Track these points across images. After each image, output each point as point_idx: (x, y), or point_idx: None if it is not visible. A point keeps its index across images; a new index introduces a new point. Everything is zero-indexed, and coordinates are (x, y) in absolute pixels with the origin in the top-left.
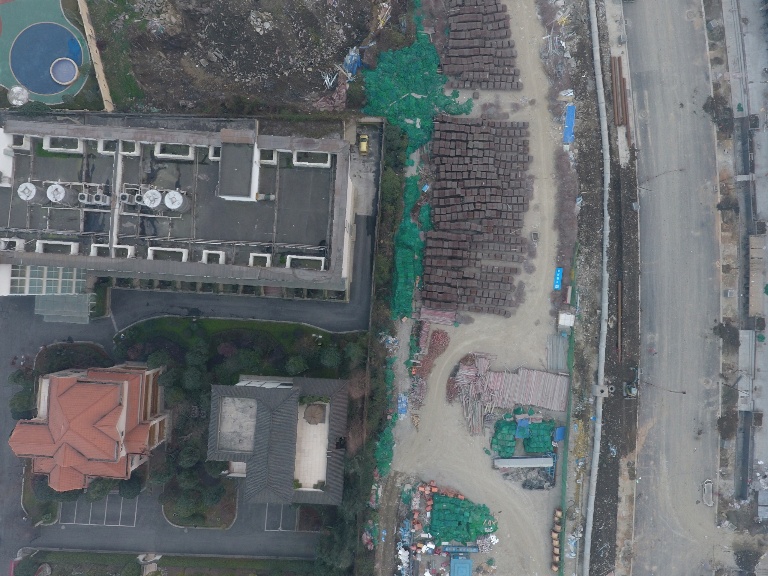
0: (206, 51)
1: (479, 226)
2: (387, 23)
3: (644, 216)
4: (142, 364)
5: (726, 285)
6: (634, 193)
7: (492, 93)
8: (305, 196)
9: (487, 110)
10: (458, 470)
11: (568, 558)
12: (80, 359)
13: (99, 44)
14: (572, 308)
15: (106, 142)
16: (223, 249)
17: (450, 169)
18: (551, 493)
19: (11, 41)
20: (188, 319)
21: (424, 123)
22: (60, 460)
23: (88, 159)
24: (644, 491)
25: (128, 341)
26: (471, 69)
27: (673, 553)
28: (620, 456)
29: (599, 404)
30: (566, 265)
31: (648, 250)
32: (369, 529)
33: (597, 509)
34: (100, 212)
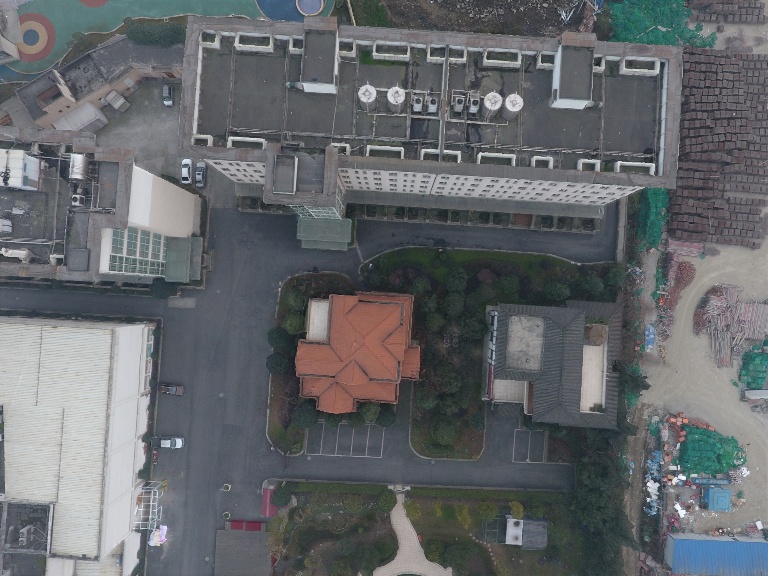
0: None
1: (729, 157)
2: None
3: None
4: None
5: None
6: None
7: (736, 27)
8: (629, 104)
9: (732, 43)
10: (706, 402)
11: None
12: (328, 289)
13: None
14: None
15: (432, 49)
16: None
17: (700, 100)
18: None
19: None
20: (434, 250)
21: None
22: (347, 378)
23: (412, 67)
24: None
25: (378, 270)
26: (720, 1)
27: None
28: None
29: None
30: None
31: None
32: None
33: None
34: (425, 119)
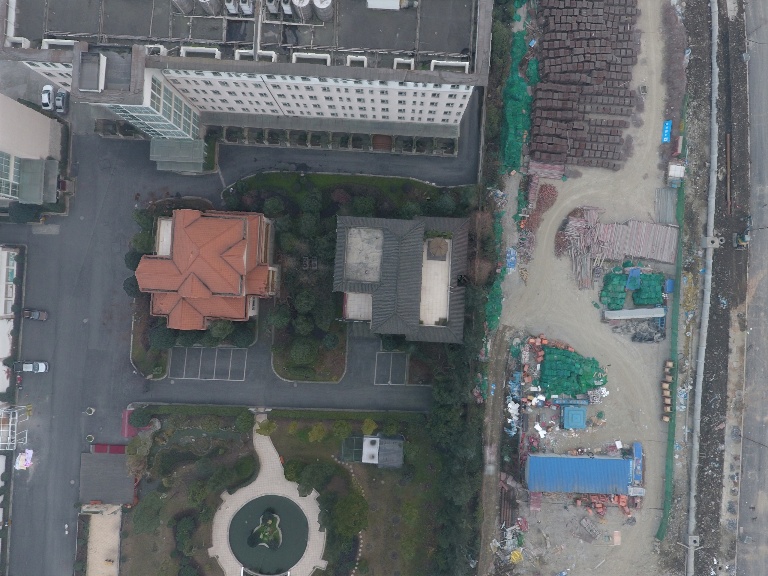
0: None
1: (589, 77)
2: None
3: (753, 68)
4: None
5: None
6: (743, 44)
7: None
8: (447, 4)
9: None
10: (567, 324)
11: (678, 411)
12: None
13: None
14: (681, 161)
15: None
16: None
17: (559, 21)
18: (660, 346)
19: None
20: (296, 174)
21: None
22: (187, 291)
23: None
24: (755, 342)
25: (238, 194)
26: None
27: None
28: (730, 307)
29: (709, 255)
30: (675, 117)
31: (757, 102)
32: (478, 383)
33: (707, 361)
34: (242, 21)
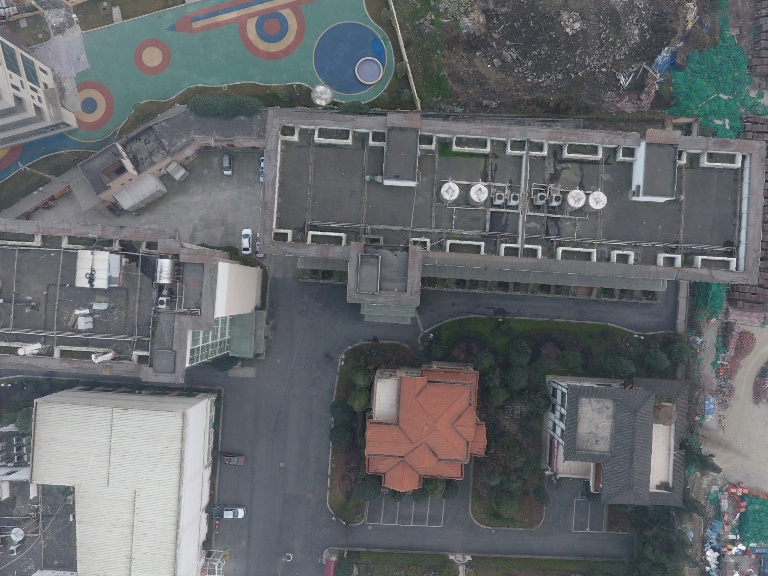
0: (499, 51)
1: None
2: (694, 24)
3: None
4: (449, 364)
5: None
6: None
7: None
8: (709, 197)
9: None
10: (765, 471)
11: None
12: (389, 359)
13: (405, 44)
14: None
15: (511, 142)
16: (627, 249)
17: None
18: None
19: (314, 40)
20: (494, 319)
21: (734, 124)
22: (418, 460)
23: (491, 159)
24: None
25: (439, 341)
26: None
27: None
28: None
29: None
30: None
31: None
32: None
33: None
34: (504, 212)
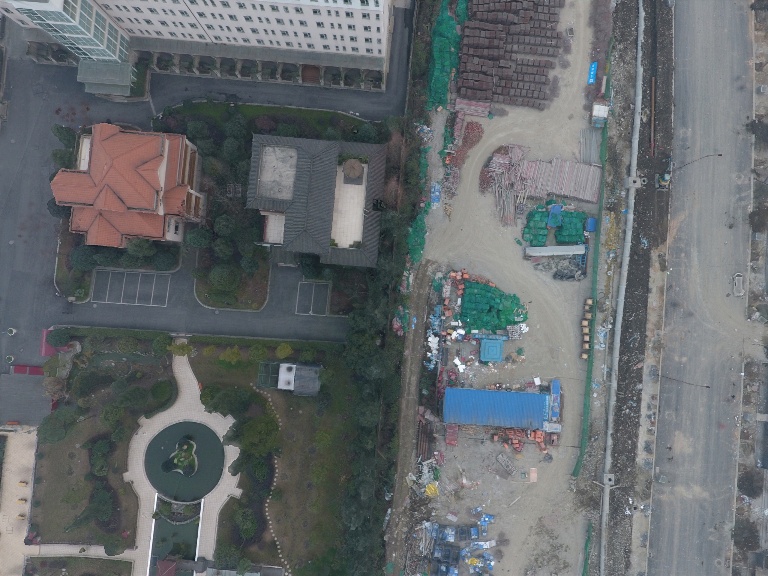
0: None
1: (516, 17)
2: None
3: (678, 14)
4: None
5: (759, 83)
6: None
7: None
8: None
9: None
10: (489, 260)
11: (597, 349)
12: None
13: None
14: (606, 102)
15: None
16: None
17: None
18: (582, 285)
19: None
20: (226, 104)
21: None
22: (101, 203)
23: None
24: (675, 283)
25: None
26: None
27: (703, 345)
28: (651, 247)
29: (631, 195)
30: (601, 58)
31: (682, 47)
32: (399, 316)
33: (627, 300)
34: None
